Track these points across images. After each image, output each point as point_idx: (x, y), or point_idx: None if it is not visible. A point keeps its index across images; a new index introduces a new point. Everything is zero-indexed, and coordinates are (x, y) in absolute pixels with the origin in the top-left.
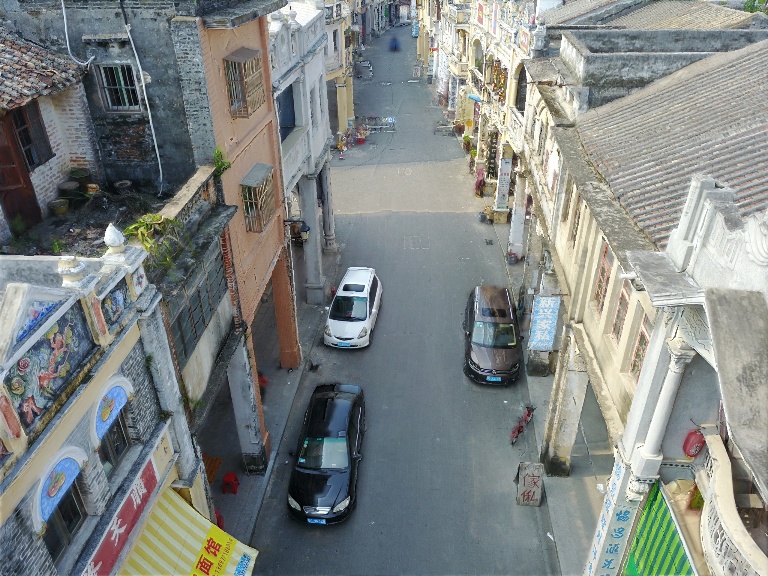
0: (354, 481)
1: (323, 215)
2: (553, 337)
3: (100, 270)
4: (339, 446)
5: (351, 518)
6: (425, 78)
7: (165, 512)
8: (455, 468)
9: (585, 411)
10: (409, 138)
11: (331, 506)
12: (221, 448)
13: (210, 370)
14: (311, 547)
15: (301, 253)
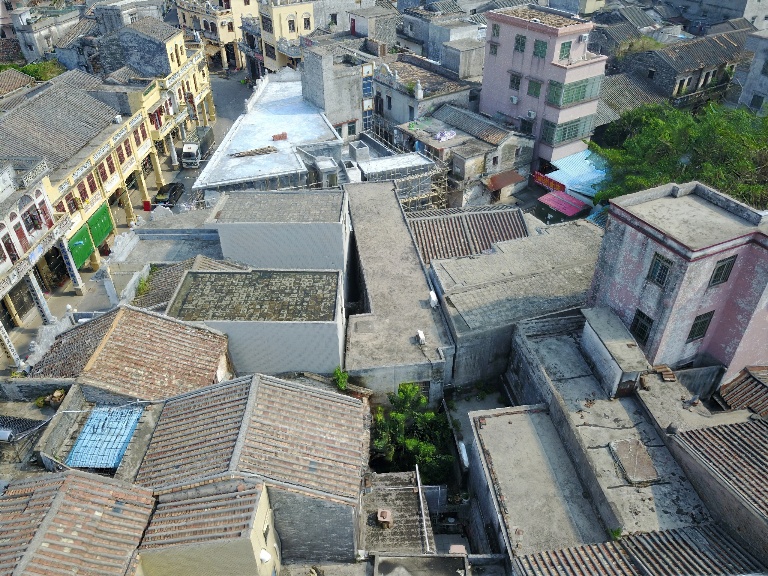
0: None
1: None
2: None
3: (30, 361)
4: None
5: None
6: None
7: None
8: None
9: None
10: None
11: None
12: None
13: None
14: None
15: None
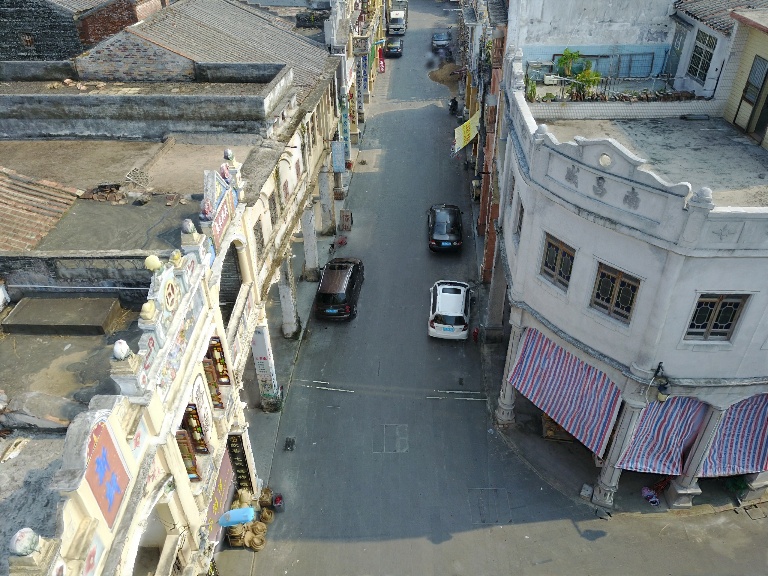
0: None
1: None
2: (334, 164)
3: None
4: None
5: None
6: None
7: None
8: None
9: (297, 256)
10: None
11: None
12: None
13: None
14: None
15: (540, 411)
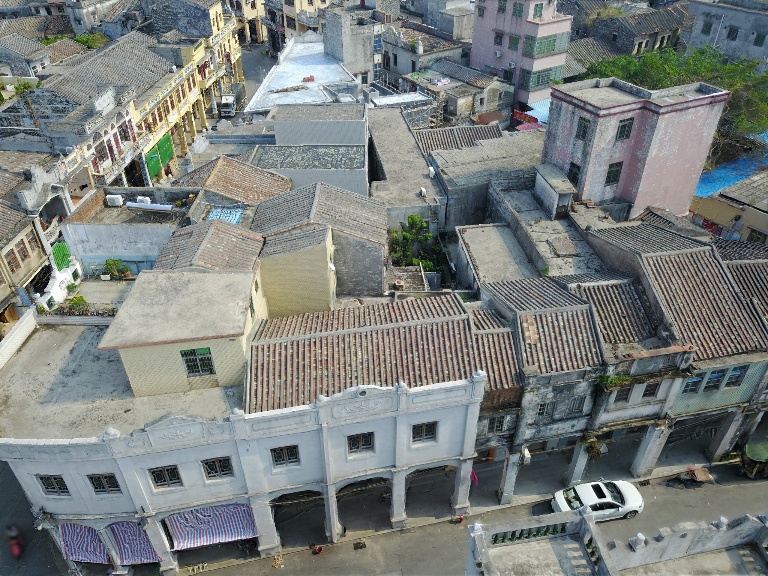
0: None
1: None
2: None
3: None
4: None
5: None
6: None
7: None
8: None
9: None
10: None
11: None
12: None
13: None
14: None
15: None
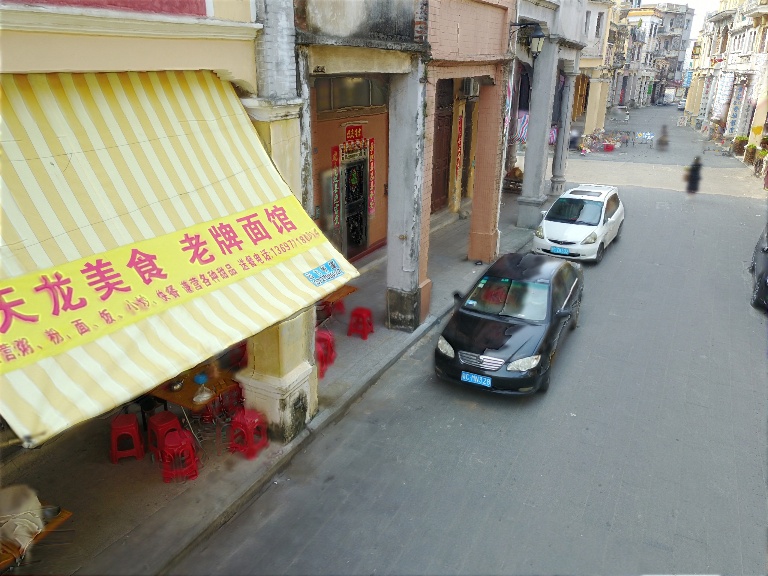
0: (551, 345)
1: (555, 149)
2: None
3: None
4: (535, 296)
5: (535, 401)
6: (692, 126)
7: (215, 115)
8: (737, 390)
9: None
10: (669, 153)
11: (505, 359)
12: (363, 301)
13: (358, 25)
14: (458, 416)
15: None
